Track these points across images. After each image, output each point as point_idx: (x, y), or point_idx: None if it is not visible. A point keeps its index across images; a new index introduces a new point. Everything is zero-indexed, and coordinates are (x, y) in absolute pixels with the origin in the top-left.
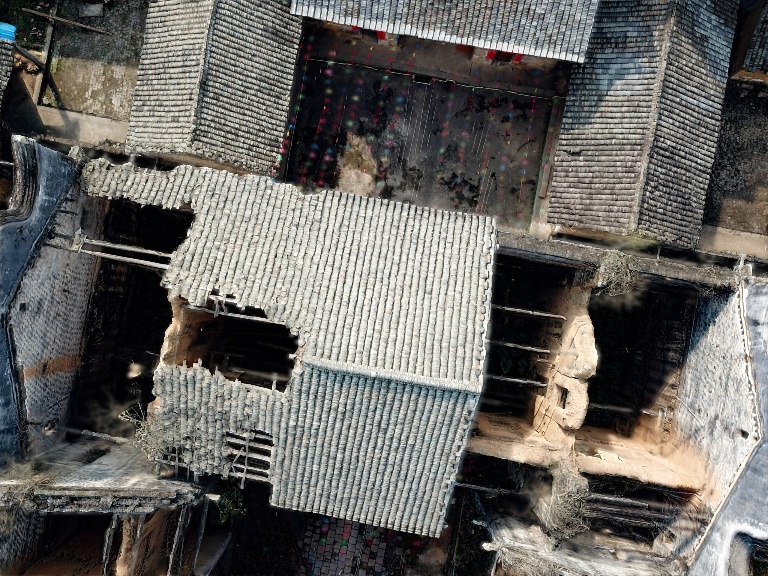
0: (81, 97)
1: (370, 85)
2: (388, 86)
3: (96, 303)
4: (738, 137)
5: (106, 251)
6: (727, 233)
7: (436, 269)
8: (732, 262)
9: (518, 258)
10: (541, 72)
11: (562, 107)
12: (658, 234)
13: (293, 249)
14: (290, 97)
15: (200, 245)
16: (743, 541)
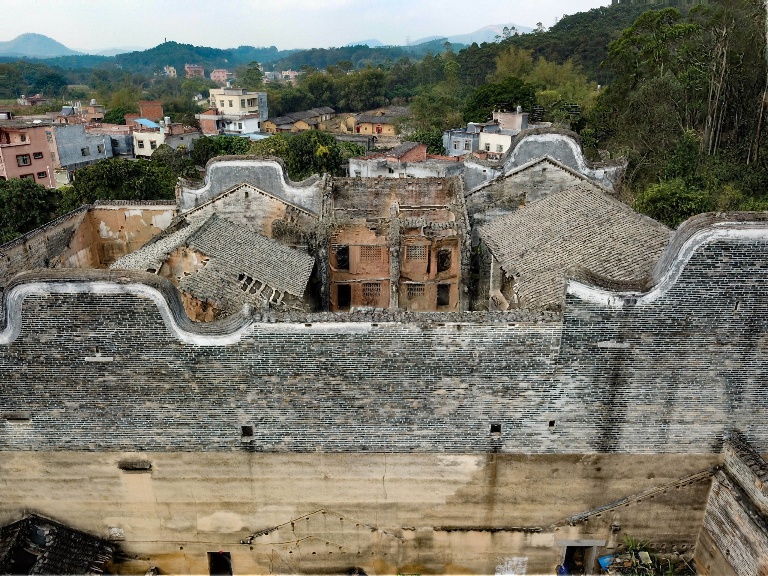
0: None
1: None
2: None
3: None
4: None
5: None
6: None
7: None
8: None
9: None
10: None
11: None
12: None
13: None
14: None
15: None
16: (289, 182)
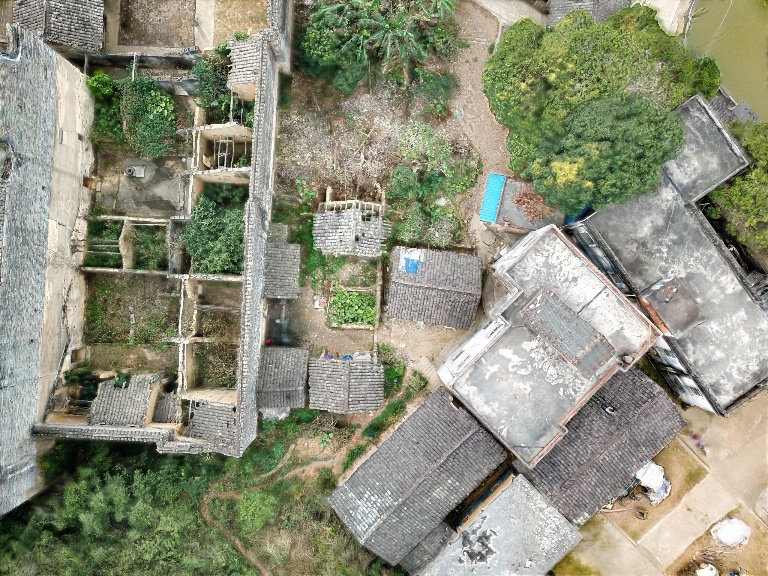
0: None
1: None
2: None
3: None
4: None
5: None
6: (155, 49)
7: None
8: (130, 58)
9: None
10: None
11: None
12: (65, 42)
13: None
14: None
15: None
16: None
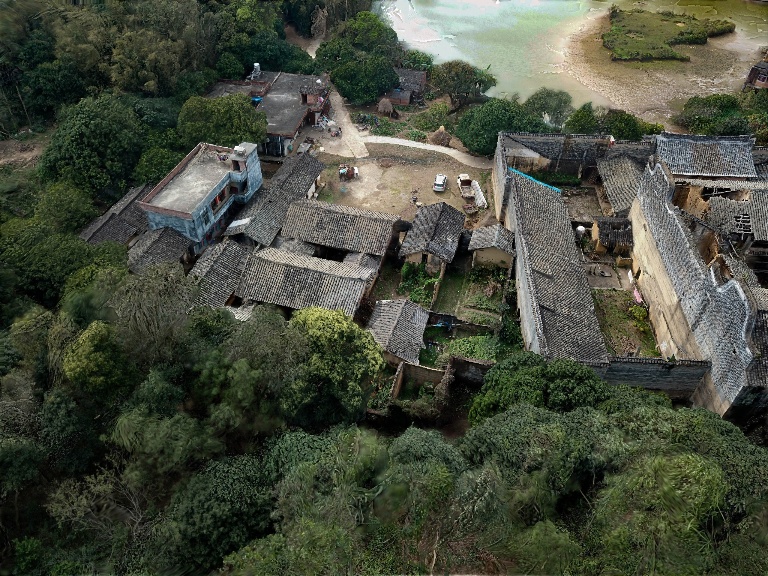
0: None
1: None
2: None
3: None
4: None
5: None
6: None
7: None
8: None
9: None
10: None
11: None
12: None
13: None
14: None
15: None
16: None
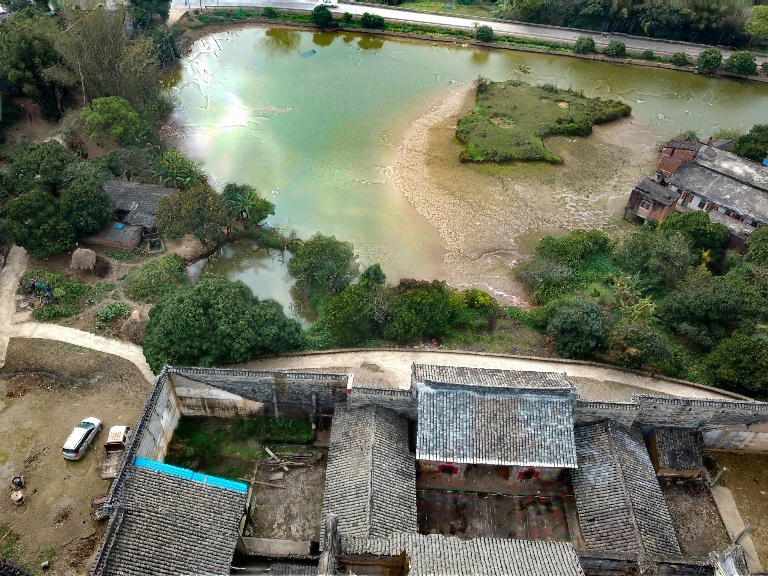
0: (270, 528)
1: (451, 502)
2: (462, 501)
3: None
4: (678, 508)
5: None
6: None
7: (552, 570)
8: None
9: (588, 575)
10: (550, 483)
11: (570, 501)
12: None
13: (471, 568)
14: (416, 507)
15: (420, 571)
16: None
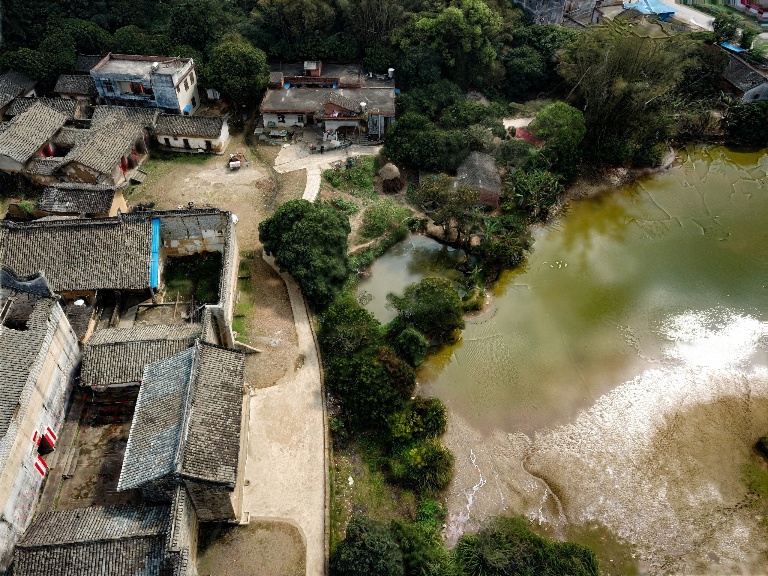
0: (143, 319)
1: None
2: None
3: (9, 323)
4: None
5: (7, 306)
6: None
7: None
8: None
9: None
10: None
11: None
12: (18, 569)
13: None
14: None
15: (5, 332)
16: None
